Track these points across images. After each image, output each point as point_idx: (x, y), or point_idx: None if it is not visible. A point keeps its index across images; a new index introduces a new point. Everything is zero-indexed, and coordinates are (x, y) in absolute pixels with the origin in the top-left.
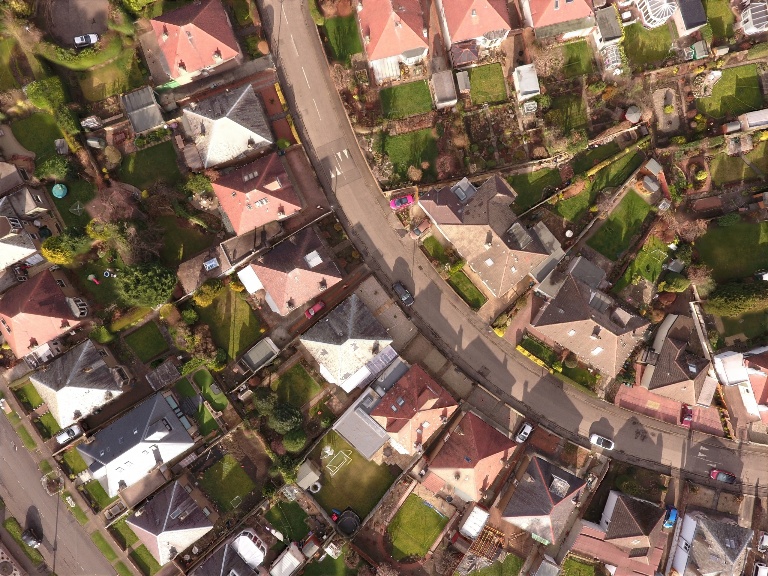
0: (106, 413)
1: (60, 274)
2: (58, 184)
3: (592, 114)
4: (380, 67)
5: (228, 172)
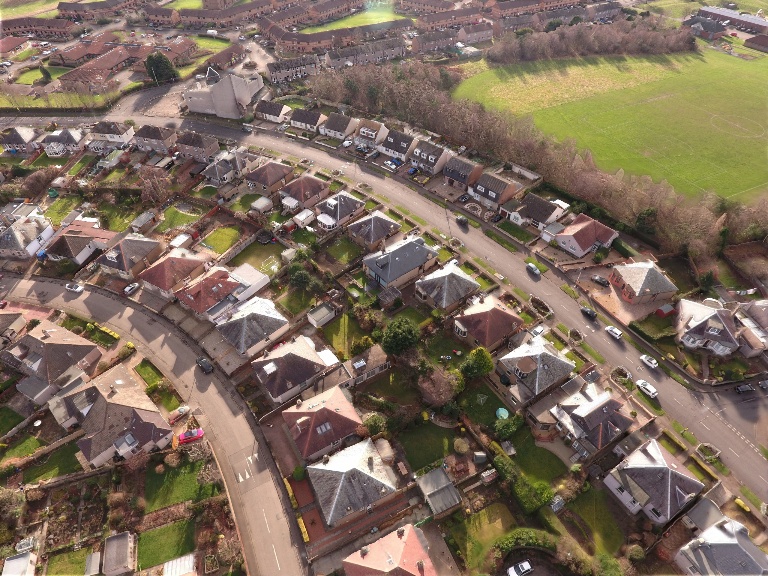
0: None
1: None
2: None
3: None
4: (186, 568)
5: (351, 439)
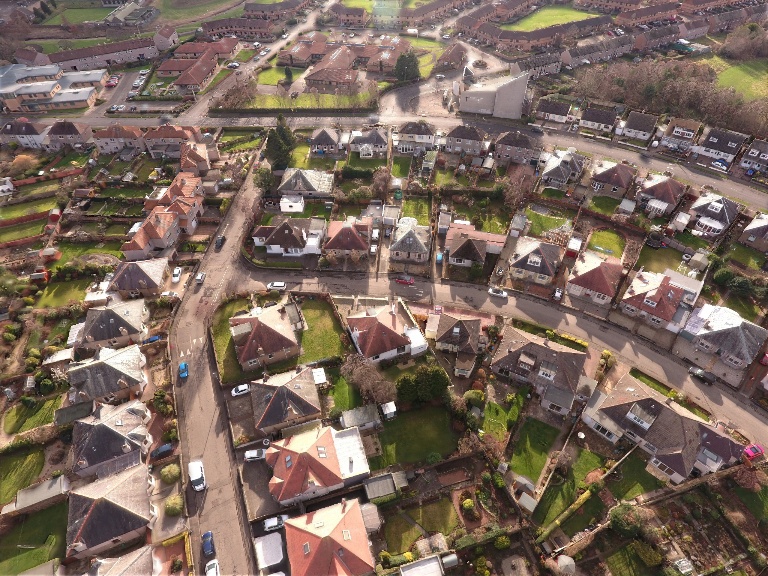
0: None
1: None
2: None
3: (605, 571)
4: None
5: None
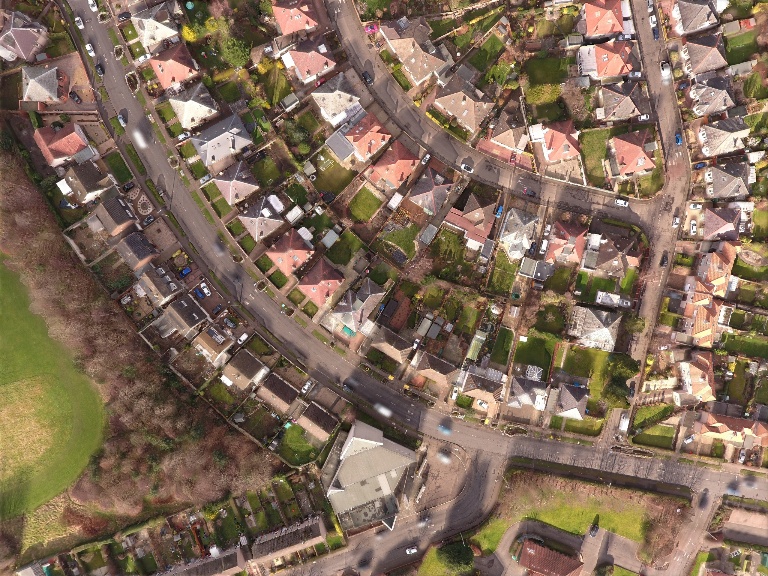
0: (205, 127)
1: (187, 49)
2: (189, 2)
3: None
4: None
5: None
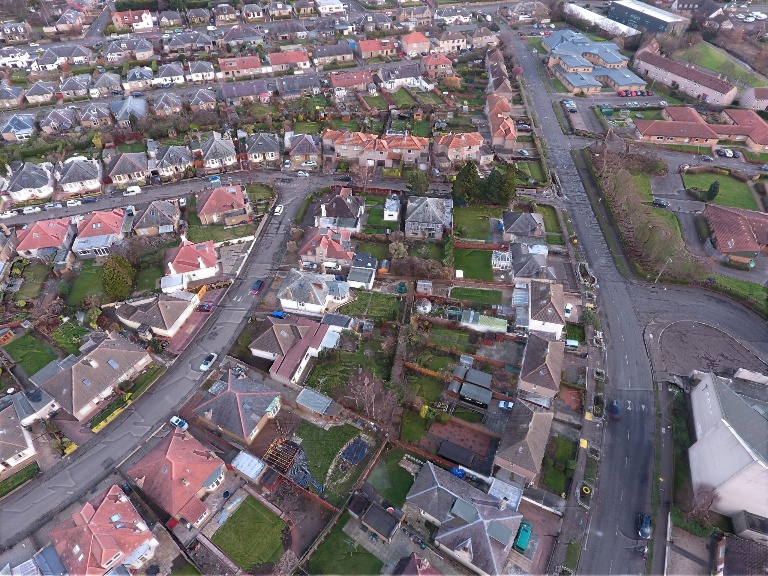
0: None
1: None
2: None
3: None
4: None
5: None
